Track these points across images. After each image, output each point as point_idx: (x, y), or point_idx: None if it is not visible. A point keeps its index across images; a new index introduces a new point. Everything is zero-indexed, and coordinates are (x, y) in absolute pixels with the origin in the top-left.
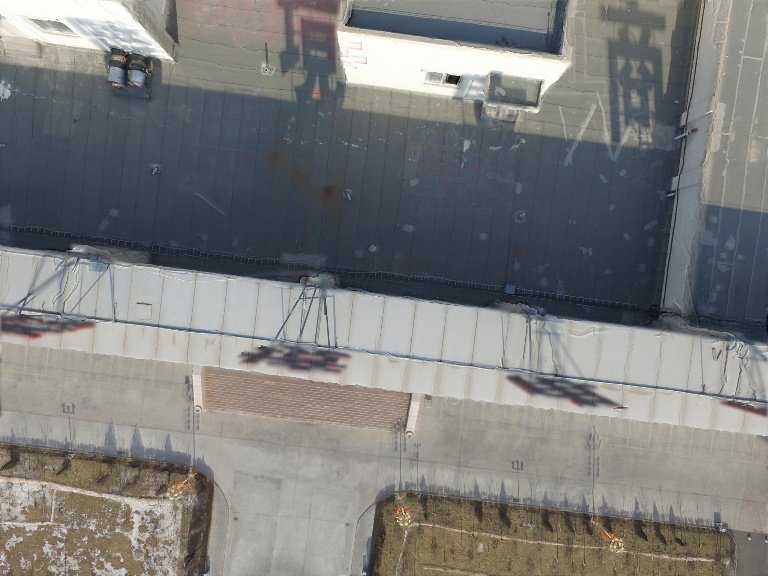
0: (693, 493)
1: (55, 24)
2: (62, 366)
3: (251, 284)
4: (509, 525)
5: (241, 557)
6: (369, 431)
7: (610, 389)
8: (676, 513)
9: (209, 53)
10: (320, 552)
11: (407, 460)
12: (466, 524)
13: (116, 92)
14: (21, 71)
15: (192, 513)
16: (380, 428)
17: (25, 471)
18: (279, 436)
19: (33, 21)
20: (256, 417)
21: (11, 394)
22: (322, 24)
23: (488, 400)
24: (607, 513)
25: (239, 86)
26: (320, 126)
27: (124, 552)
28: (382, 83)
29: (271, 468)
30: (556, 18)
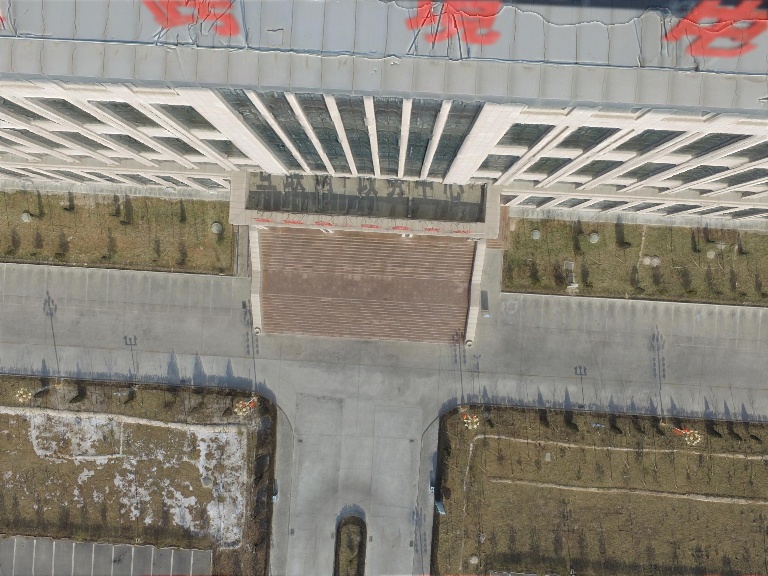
0: (765, 389)
1: None
2: (122, 299)
3: (379, 3)
4: (577, 429)
5: (308, 479)
6: (427, 345)
7: (753, 81)
8: (748, 411)
9: None
10: (386, 470)
11: (468, 372)
12: (532, 434)
13: None
14: None
15: (257, 437)
16: (438, 341)
17: (92, 405)
18: (338, 355)
19: None
20: (314, 338)
21: (75, 330)
22: None
23: (627, 101)
24: (676, 414)
25: None
26: None
27: (193, 480)
28: None
29: (332, 388)
30: None
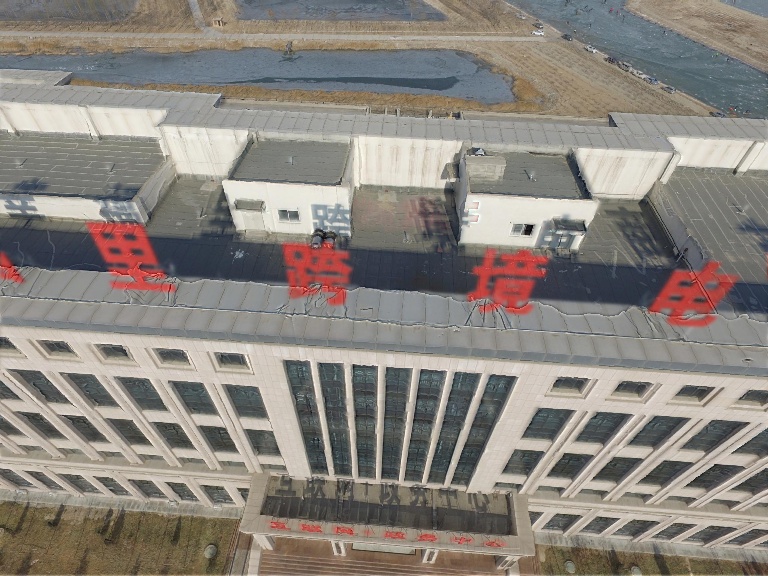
0: None
1: (291, 214)
2: None
3: None
4: None
5: None
6: None
7: (730, 349)
8: None
9: (371, 235)
10: None
11: None
12: None
13: (312, 252)
14: (252, 245)
15: None
16: None
17: None
18: None
19: (279, 213)
20: None
21: None
22: (437, 223)
23: (641, 359)
24: None
25: (390, 248)
26: (445, 265)
27: None
28: (483, 239)
29: None
30: (581, 191)
